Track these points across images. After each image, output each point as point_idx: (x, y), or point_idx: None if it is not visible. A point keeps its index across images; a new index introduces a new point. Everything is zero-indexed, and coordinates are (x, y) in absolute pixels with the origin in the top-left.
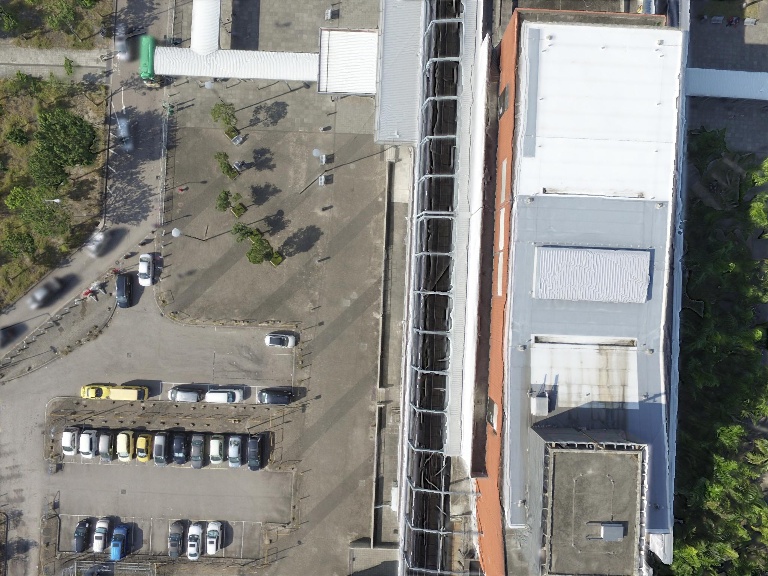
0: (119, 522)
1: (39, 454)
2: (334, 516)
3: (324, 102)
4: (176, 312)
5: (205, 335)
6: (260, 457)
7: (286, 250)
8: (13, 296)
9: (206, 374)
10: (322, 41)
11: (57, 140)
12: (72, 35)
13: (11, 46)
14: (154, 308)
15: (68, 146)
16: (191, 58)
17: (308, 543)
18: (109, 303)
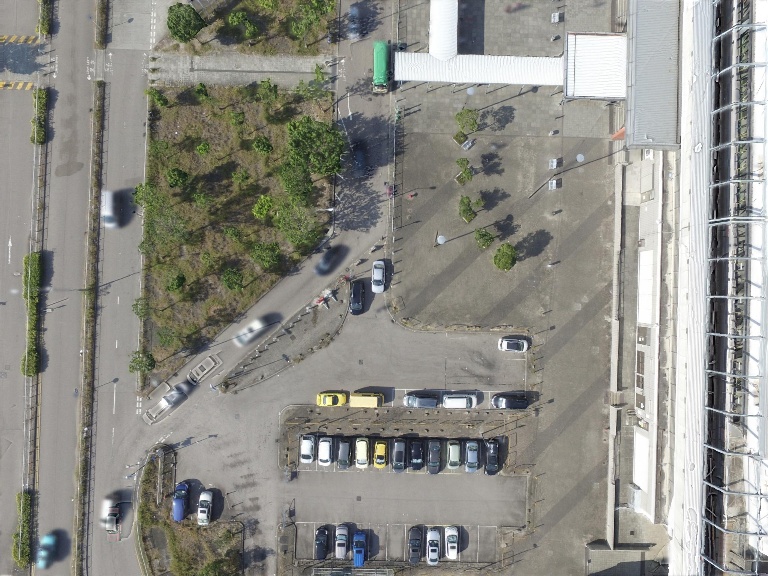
0: (355, 529)
1: (274, 462)
2: (569, 519)
3: (551, 106)
4: (407, 318)
5: (436, 341)
6: (497, 462)
7: (516, 255)
8: (245, 305)
9: (438, 380)
10: (569, 45)
11: (311, 148)
12: (297, 41)
13: (235, 53)
14: (385, 315)
15: (322, 154)
16: (431, 63)
17: (544, 546)
18: (340, 310)
